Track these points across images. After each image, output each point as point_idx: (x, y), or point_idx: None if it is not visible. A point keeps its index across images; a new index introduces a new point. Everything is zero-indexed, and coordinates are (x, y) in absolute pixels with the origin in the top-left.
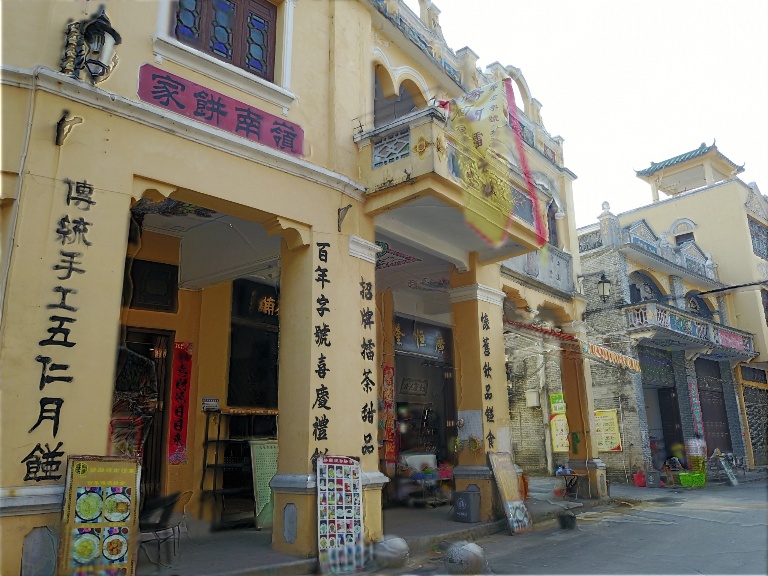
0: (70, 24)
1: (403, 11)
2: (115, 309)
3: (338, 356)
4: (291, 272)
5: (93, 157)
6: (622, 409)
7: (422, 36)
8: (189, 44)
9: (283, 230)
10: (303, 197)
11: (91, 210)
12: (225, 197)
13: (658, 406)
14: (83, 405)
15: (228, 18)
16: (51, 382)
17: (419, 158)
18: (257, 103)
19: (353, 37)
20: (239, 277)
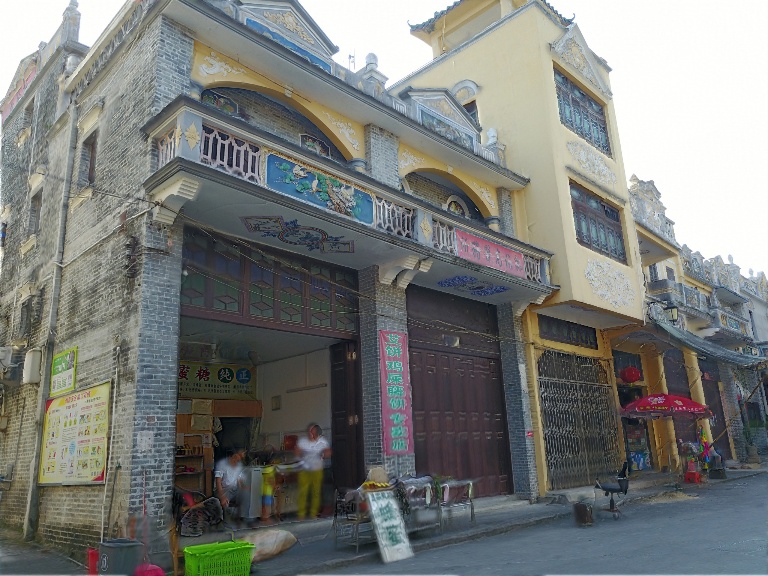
0: None
1: None
2: None
3: None
4: None
5: None
6: (117, 376)
7: None
8: None
9: None
10: None
11: None
12: None
13: (329, 380)
14: None
15: None
16: None
17: None
18: None
19: None
20: None
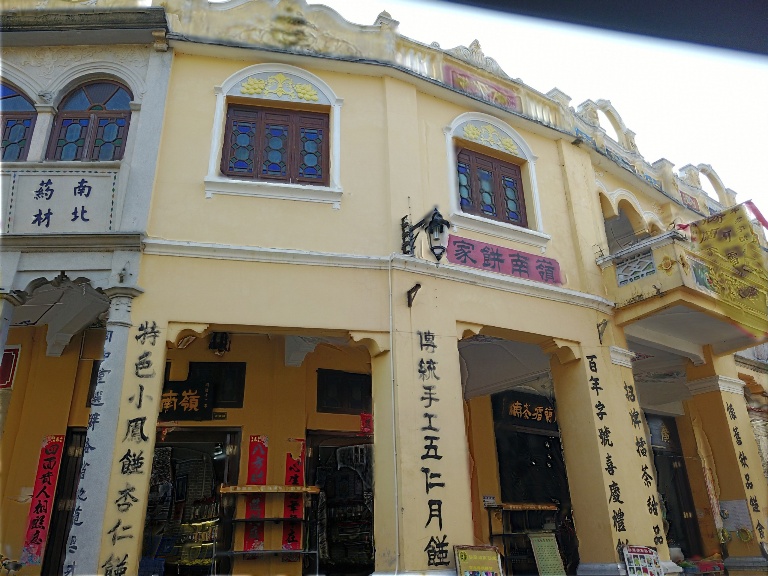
0: (403, 217)
1: (608, 142)
2: (461, 427)
3: (620, 454)
4: (565, 383)
5: (430, 312)
6: None
7: (625, 158)
8: (468, 211)
9: (558, 349)
10: (569, 319)
11: (435, 352)
12: (516, 328)
13: None
14: (454, 505)
15: (489, 184)
16: (432, 487)
17: (667, 275)
18: (523, 248)
19: (580, 177)
20: (508, 388)
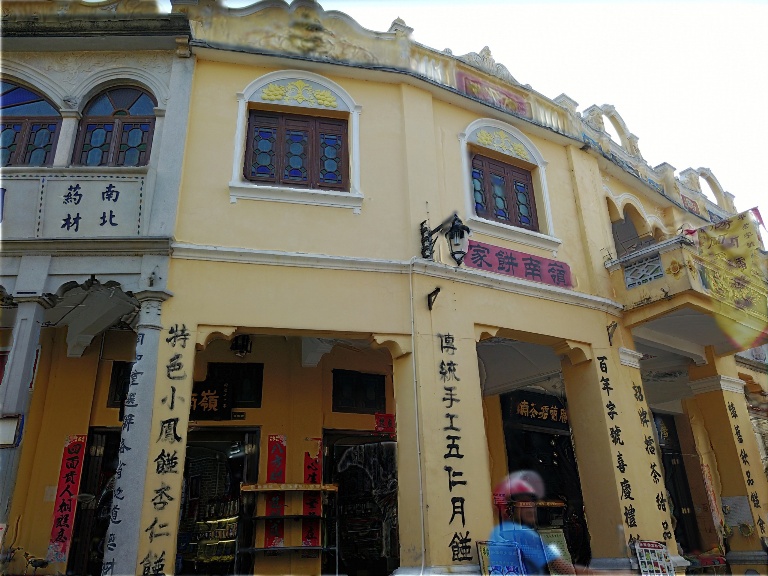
0: (422, 222)
1: (613, 147)
2: (481, 427)
3: (631, 453)
4: (576, 383)
5: (449, 315)
6: None
7: (629, 163)
8: (482, 216)
9: (570, 350)
10: (581, 321)
11: (455, 354)
12: (531, 330)
13: None
14: (475, 502)
15: (502, 189)
16: (455, 485)
17: (675, 278)
18: (535, 252)
19: (589, 182)
20: (519, 388)
